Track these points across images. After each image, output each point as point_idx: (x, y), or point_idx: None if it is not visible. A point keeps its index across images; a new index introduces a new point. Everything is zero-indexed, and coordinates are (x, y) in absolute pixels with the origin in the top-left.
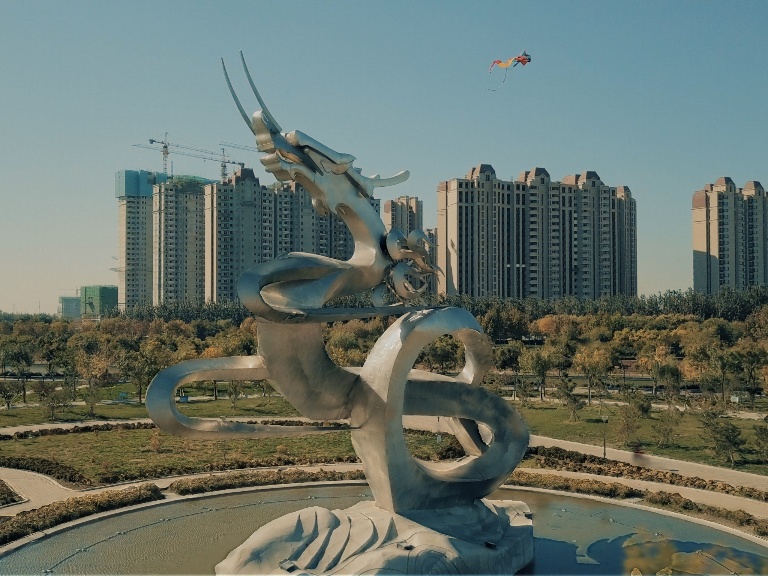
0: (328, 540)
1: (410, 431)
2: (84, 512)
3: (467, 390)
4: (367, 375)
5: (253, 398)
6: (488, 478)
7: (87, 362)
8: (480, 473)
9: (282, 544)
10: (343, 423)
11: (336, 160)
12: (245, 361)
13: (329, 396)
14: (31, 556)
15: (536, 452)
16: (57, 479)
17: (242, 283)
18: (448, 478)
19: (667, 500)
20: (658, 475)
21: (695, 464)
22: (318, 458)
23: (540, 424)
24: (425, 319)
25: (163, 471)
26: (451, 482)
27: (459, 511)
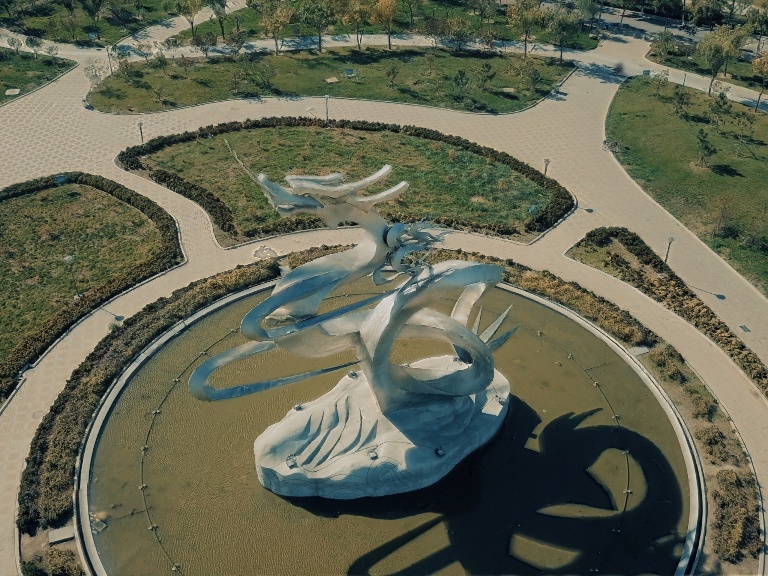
0: (325, 439)
1: (525, 171)
2: (216, 296)
3: (453, 334)
4: (364, 334)
5: (419, 60)
6: (459, 394)
7: (270, 14)
8: (456, 388)
9: (292, 442)
10: (473, 142)
11: (335, 196)
12: (263, 343)
13: (335, 345)
14: (172, 354)
15: (616, 236)
16: (214, 224)
17: (244, 325)
18: (430, 389)
19: (663, 363)
20: (694, 309)
21: (751, 287)
22: (422, 215)
23: (664, 165)
24: (415, 296)
25: (291, 225)
26: (430, 394)
27: (436, 409)
